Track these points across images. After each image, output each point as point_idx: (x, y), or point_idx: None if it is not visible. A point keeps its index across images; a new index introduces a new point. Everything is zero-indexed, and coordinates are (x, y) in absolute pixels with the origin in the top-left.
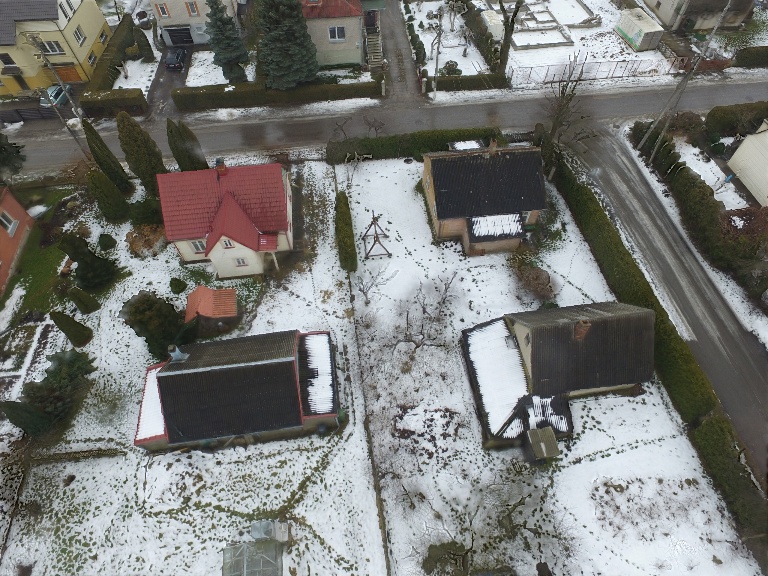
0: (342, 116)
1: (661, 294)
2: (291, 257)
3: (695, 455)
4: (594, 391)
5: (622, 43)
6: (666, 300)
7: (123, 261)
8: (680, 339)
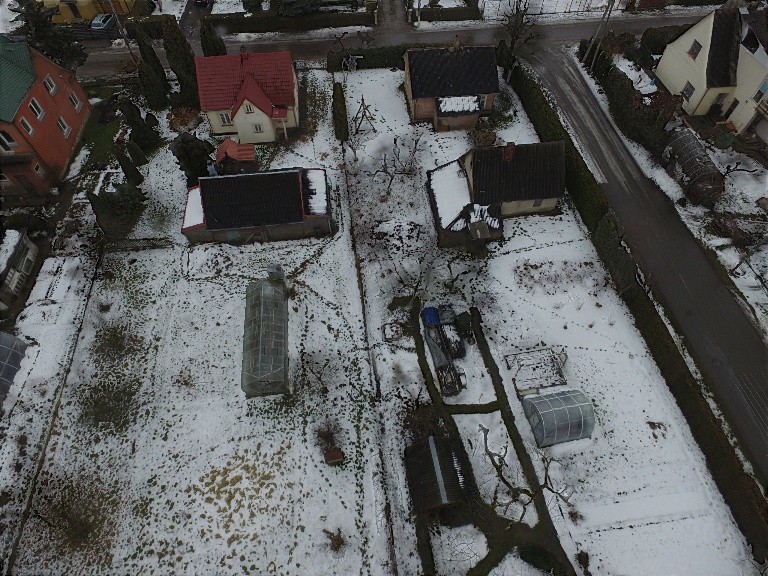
0: (341, 39)
1: (585, 155)
2: (297, 132)
3: (594, 250)
4: (524, 211)
5: None
6: (588, 159)
7: (165, 134)
8: (588, 170)
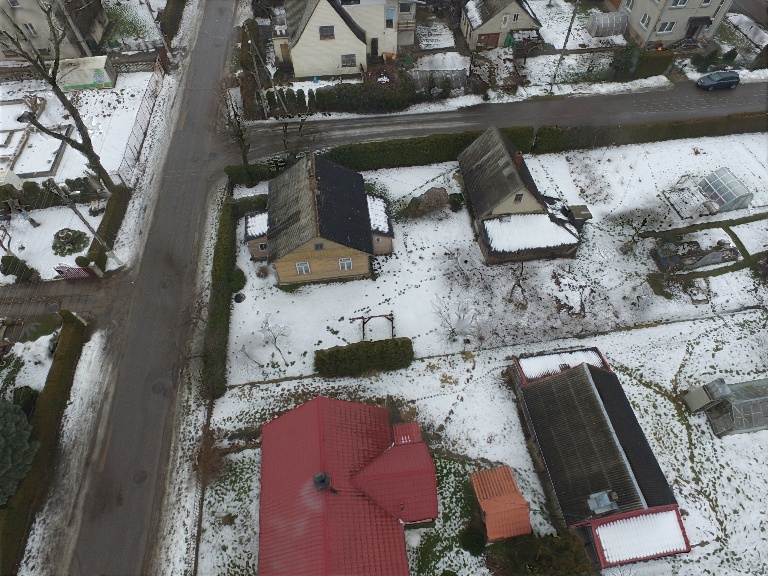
0: (115, 382)
1: None
2: None
3: (549, 154)
4: None
5: (97, 91)
6: None
7: None
8: None
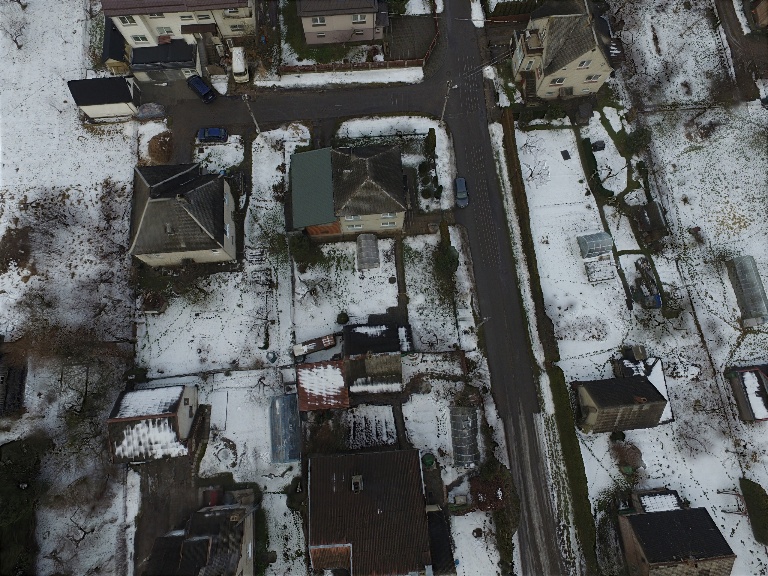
0: None
1: (544, 448)
2: None
3: None
4: None
5: None
6: (542, 443)
7: None
8: (565, 404)
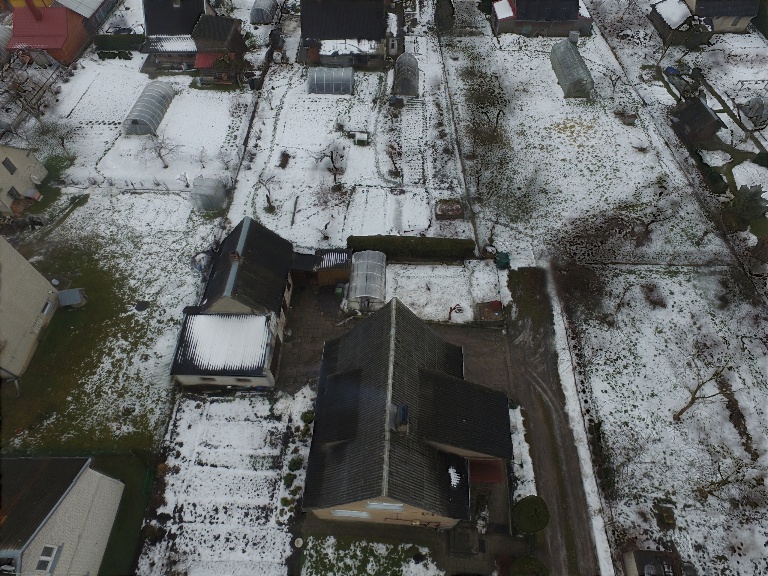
0: None
1: None
2: None
3: None
4: (723, 29)
5: None
6: None
7: None
8: None
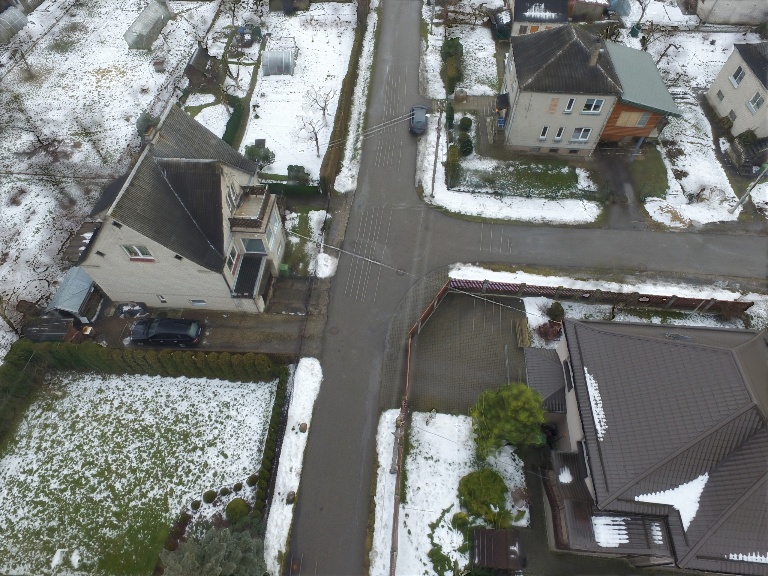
0: None
1: None
2: None
3: None
4: None
5: None
6: None
7: None
8: None
